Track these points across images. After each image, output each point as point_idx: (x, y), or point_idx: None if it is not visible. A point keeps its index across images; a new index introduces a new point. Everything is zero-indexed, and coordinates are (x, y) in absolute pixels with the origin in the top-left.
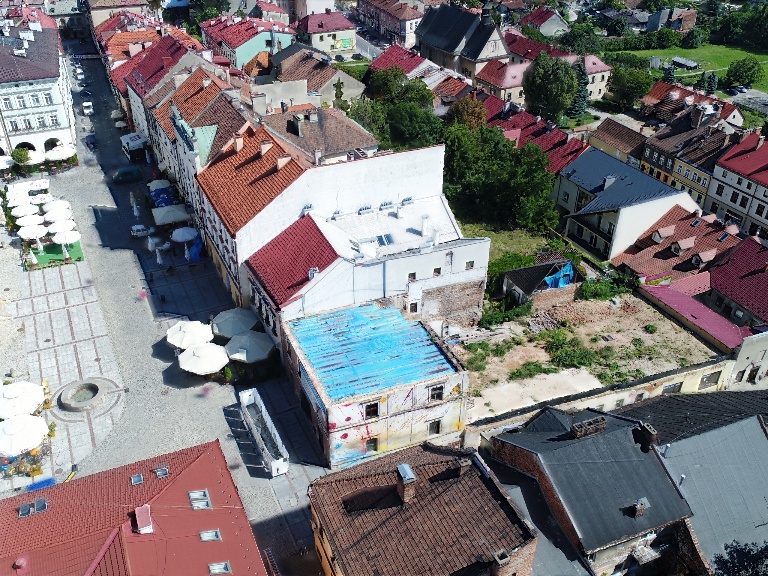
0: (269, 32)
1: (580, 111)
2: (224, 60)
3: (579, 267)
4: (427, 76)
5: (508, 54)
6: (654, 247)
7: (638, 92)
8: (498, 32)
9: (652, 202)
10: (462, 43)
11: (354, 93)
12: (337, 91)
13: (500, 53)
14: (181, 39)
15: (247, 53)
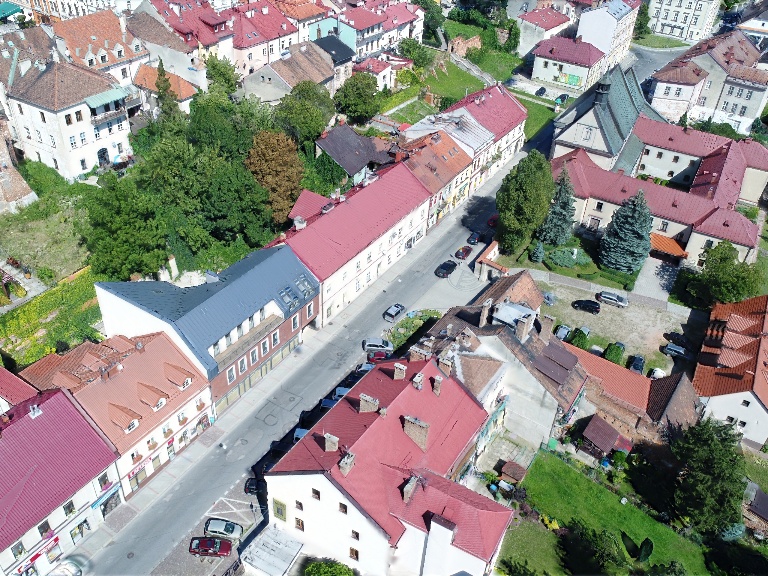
0: (337, 19)
1: (617, 265)
2: (214, 21)
3: (3, 296)
4: (437, 123)
5: (610, 152)
6: (110, 351)
7: (712, 289)
8: (596, 117)
9: (128, 303)
10: (571, 115)
11: (282, 94)
12: (158, 68)
13: (597, 146)
14: (290, 3)
15: None
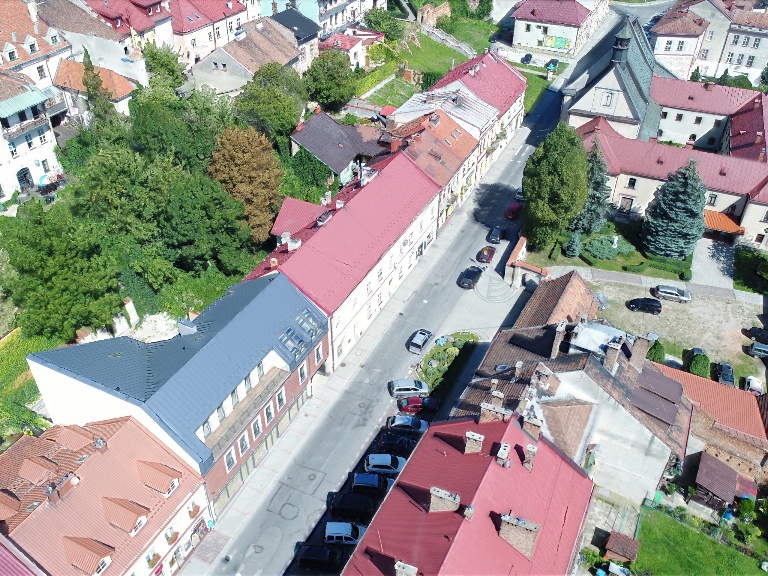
0: None
1: (667, 251)
2: (146, 2)
3: None
4: (430, 101)
5: (635, 118)
6: (58, 448)
7: None
8: (618, 78)
9: (76, 381)
10: (582, 79)
11: (241, 82)
12: (83, 60)
13: (620, 112)
14: None
15: (271, 9)
